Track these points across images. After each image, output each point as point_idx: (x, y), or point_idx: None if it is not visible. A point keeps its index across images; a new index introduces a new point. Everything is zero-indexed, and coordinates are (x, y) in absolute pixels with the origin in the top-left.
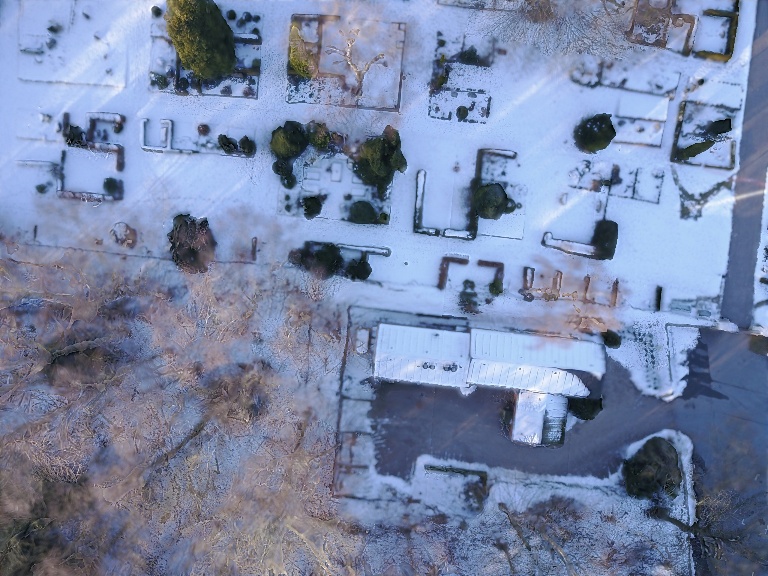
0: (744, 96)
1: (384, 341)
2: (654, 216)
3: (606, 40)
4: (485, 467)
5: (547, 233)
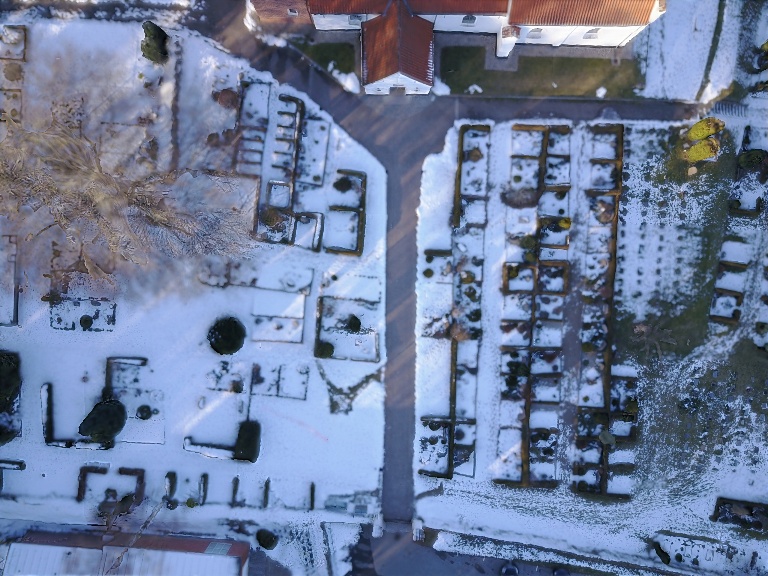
0: (383, 288)
1: (13, 563)
2: (303, 412)
3: (232, 240)
4: None
5: (185, 439)
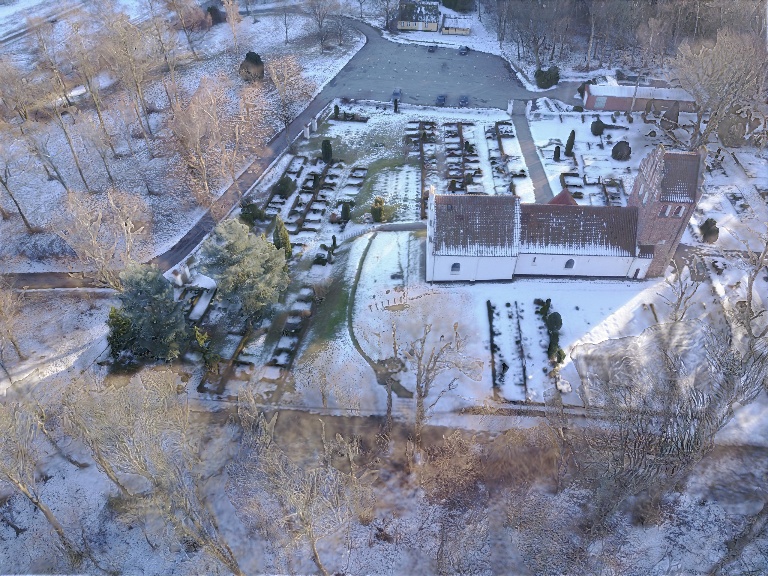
0: None
1: None
2: None
3: None
4: (618, 82)
5: None
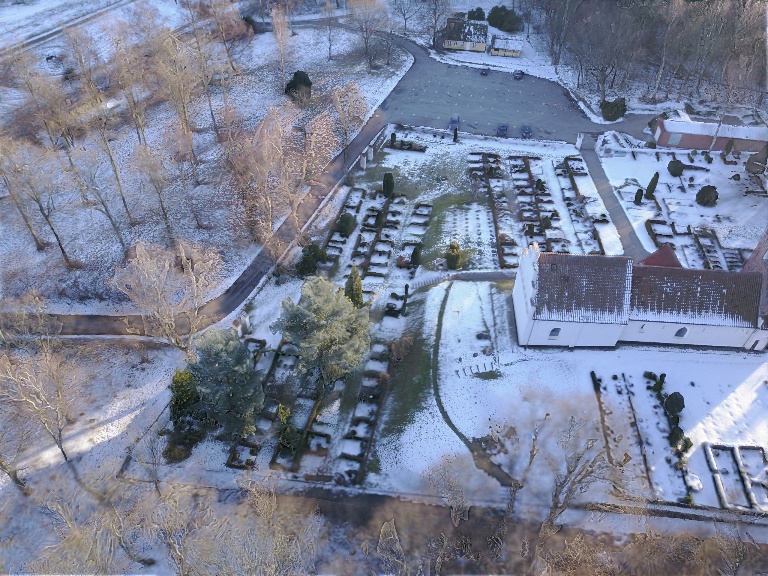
0: None
1: None
2: None
3: None
4: None
5: None
